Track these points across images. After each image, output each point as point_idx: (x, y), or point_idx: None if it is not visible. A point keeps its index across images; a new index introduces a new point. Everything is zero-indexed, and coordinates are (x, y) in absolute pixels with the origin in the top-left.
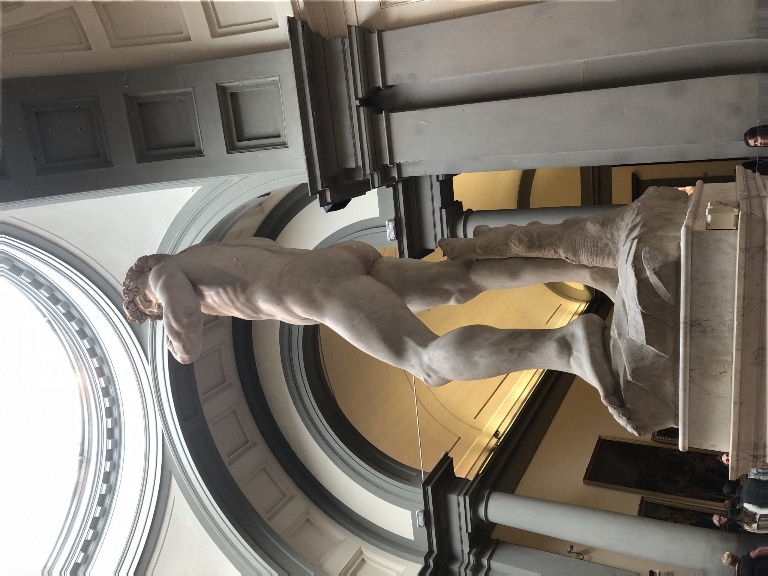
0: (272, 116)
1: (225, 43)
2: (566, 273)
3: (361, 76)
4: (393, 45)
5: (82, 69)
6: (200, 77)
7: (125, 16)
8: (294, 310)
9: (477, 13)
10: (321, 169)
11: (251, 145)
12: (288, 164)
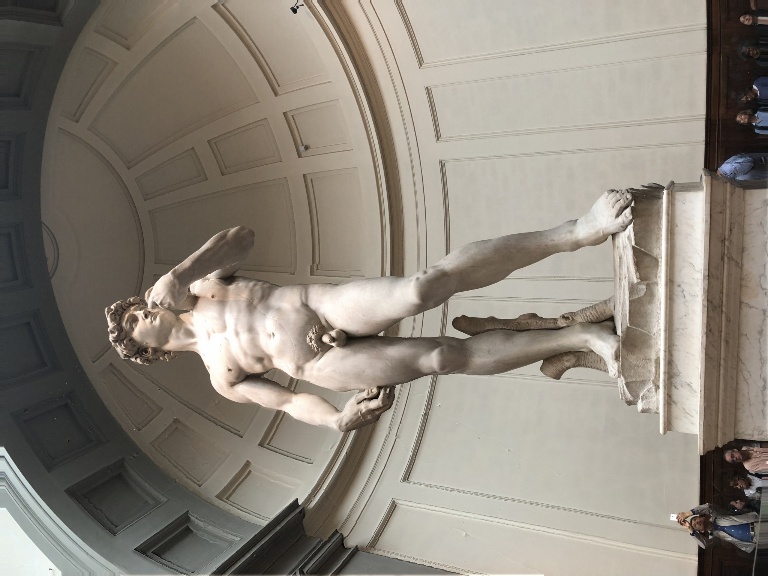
0: (202, 561)
1: (220, 506)
2: (556, 332)
3: (319, 560)
4: (362, 560)
5: (122, 426)
6: (182, 499)
7: (179, 444)
8: (310, 288)
9: (449, 571)
10: None
11: (160, 561)
12: None
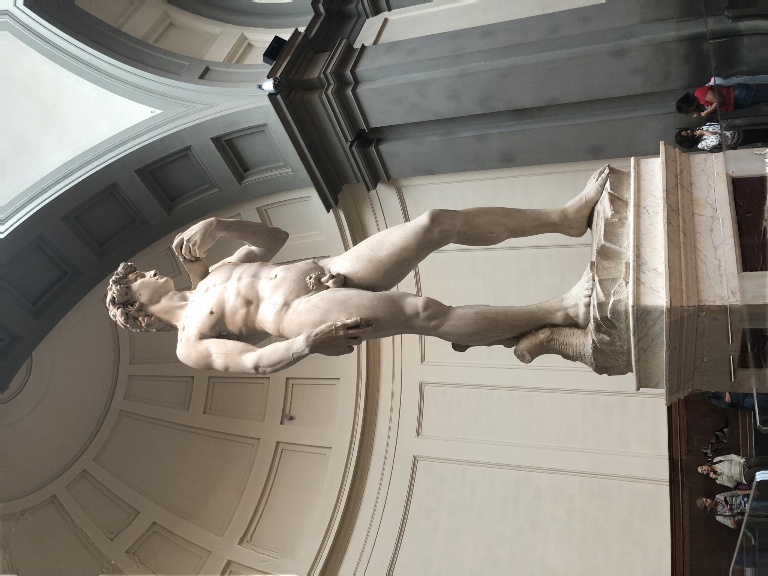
0: None
1: None
2: None
3: None
4: None
5: None
6: None
7: None
8: None
9: None
10: None
11: None
12: None
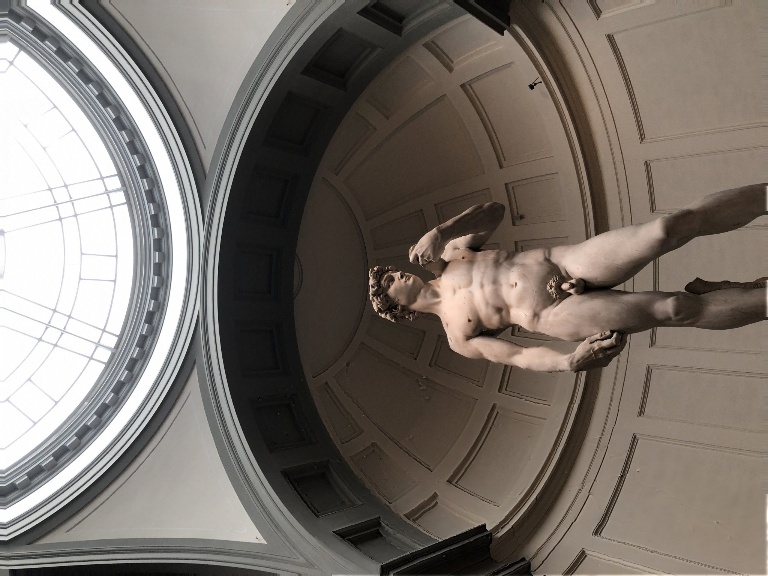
0: None
1: None
2: None
3: (506, 575)
4: None
5: None
6: (375, 506)
7: (374, 465)
8: None
9: None
10: (408, 571)
11: None
12: (370, 569)
